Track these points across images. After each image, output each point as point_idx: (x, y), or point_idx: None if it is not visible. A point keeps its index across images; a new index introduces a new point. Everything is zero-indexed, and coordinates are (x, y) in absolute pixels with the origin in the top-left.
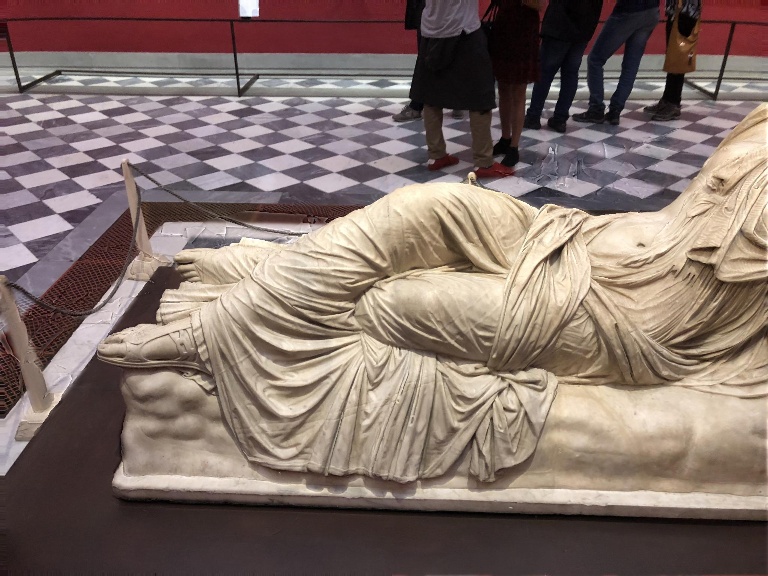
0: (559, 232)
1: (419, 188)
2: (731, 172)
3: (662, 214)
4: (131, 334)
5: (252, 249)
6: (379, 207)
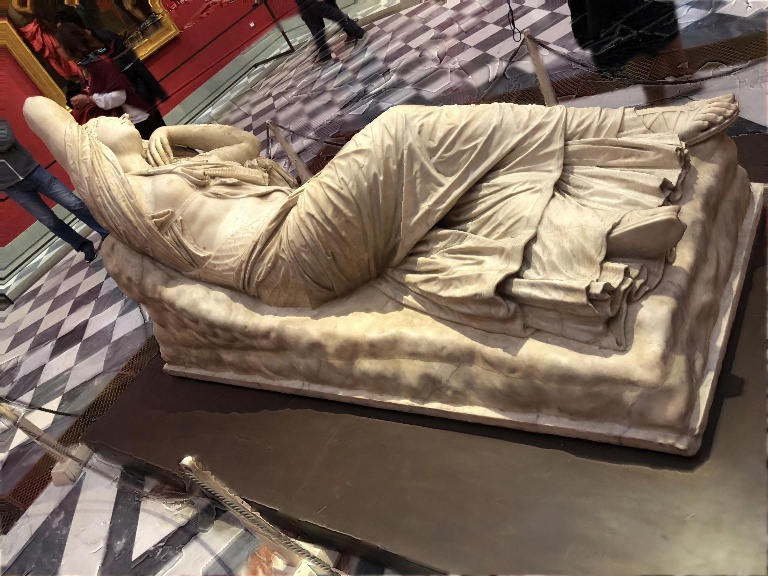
0: None
1: (390, 109)
2: (196, 170)
3: (228, 215)
4: (700, 106)
5: (568, 219)
6: (430, 107)
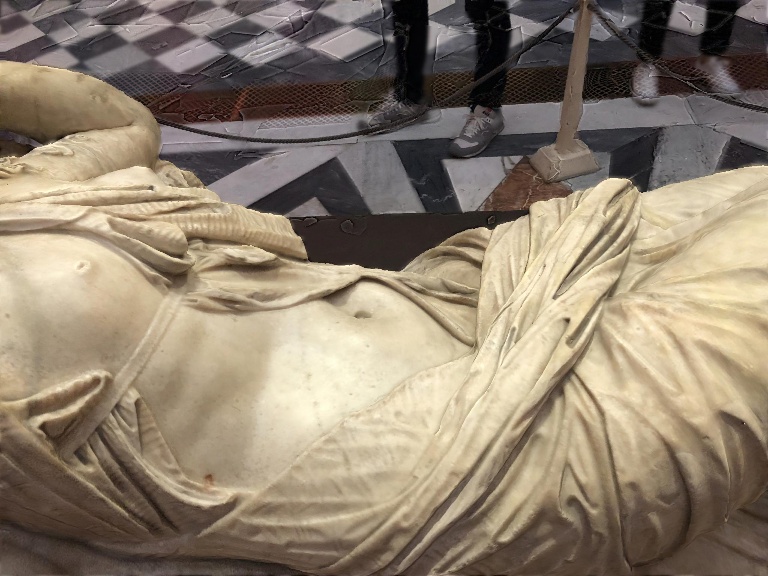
0: (545, 273)
1: None
2: (150, 224)
3: (274, 364)
4: None
5: None
6: None
